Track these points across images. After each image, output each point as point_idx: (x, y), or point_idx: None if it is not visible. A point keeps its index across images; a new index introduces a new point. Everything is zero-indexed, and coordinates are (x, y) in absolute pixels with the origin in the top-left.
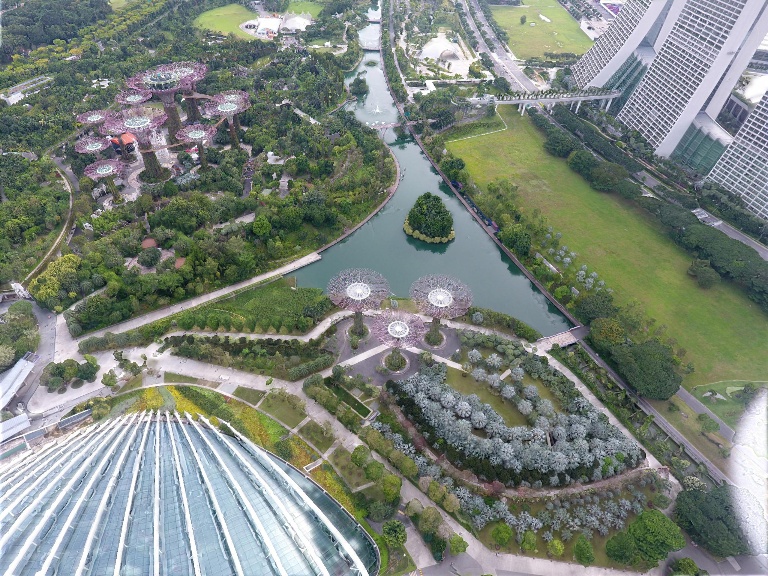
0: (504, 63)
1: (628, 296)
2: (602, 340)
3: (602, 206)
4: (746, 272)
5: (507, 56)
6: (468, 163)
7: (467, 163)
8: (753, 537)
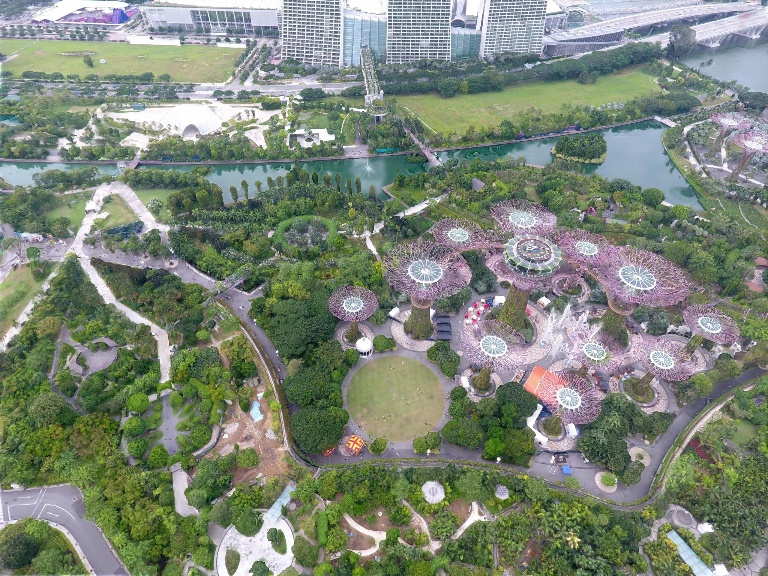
0: (234, 90)
1: (616, 101)
2: (675, 106)
3: (521, 93)
4: (589, 66)
5: (210, 87)
6: (479, 129)
7: (479, 130)
8: (766, 94)
